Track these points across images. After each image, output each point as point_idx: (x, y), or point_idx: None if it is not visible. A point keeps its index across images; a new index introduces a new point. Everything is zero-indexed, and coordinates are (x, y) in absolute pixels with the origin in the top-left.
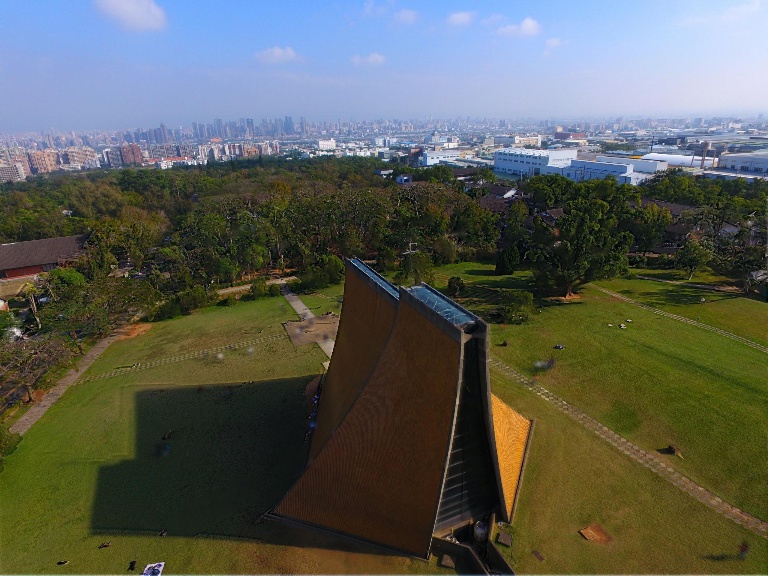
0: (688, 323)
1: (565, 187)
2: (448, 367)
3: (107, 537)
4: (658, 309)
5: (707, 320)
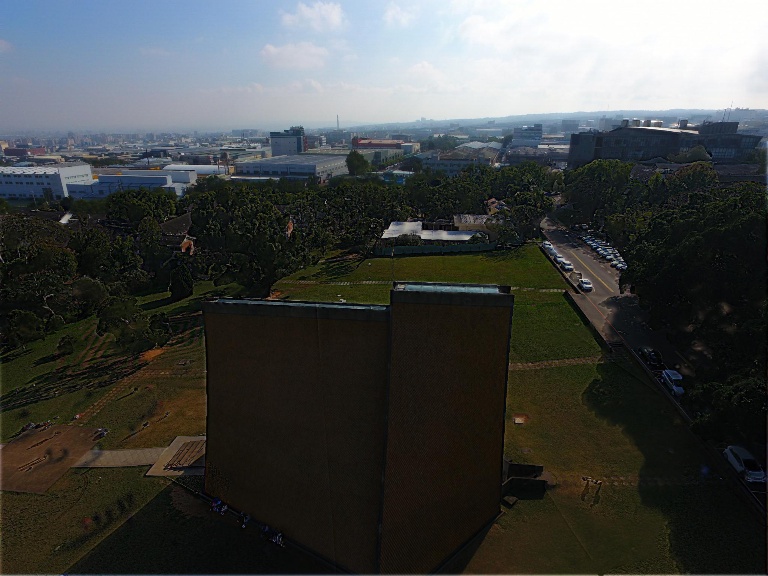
0: (369, 284)
1: (157, 200)
2: (495, 334)
3: None
4: (341, 282)
5: (375, 278)
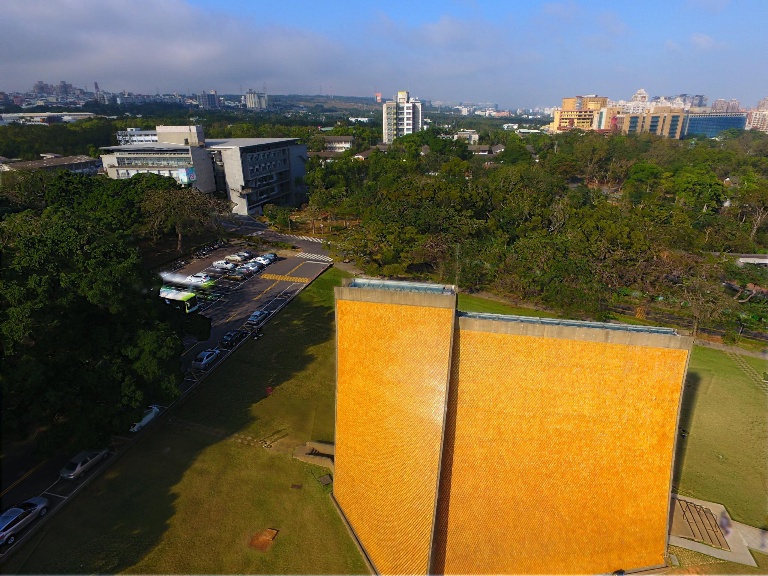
0: None
1: None
2: None
3: None
4: None
5: None
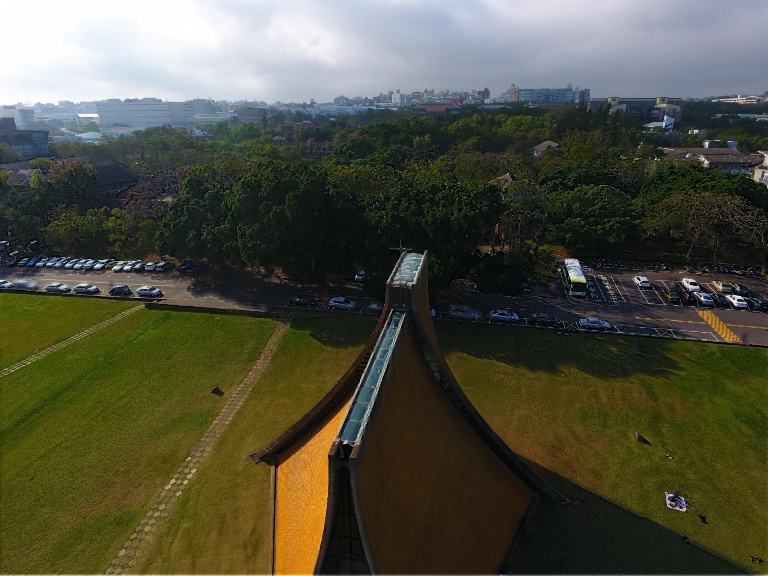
0: None
1: None
2: None
3: (763, 571)
4: None
5: None
